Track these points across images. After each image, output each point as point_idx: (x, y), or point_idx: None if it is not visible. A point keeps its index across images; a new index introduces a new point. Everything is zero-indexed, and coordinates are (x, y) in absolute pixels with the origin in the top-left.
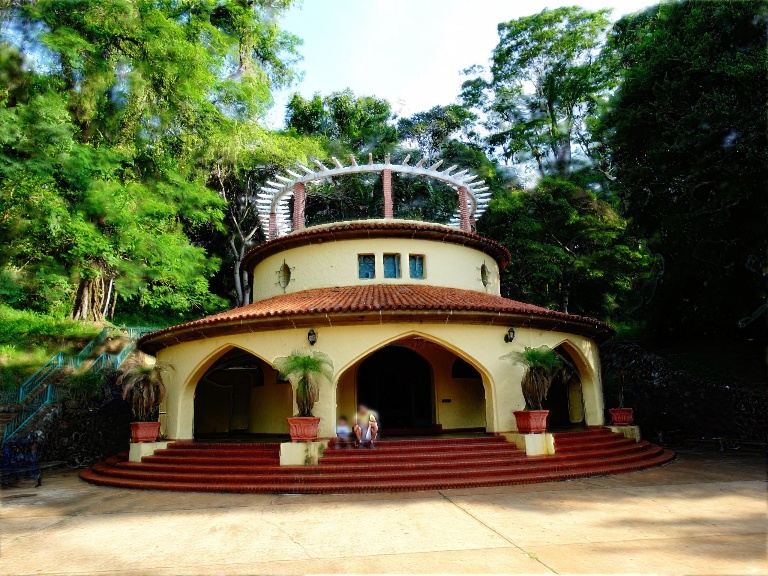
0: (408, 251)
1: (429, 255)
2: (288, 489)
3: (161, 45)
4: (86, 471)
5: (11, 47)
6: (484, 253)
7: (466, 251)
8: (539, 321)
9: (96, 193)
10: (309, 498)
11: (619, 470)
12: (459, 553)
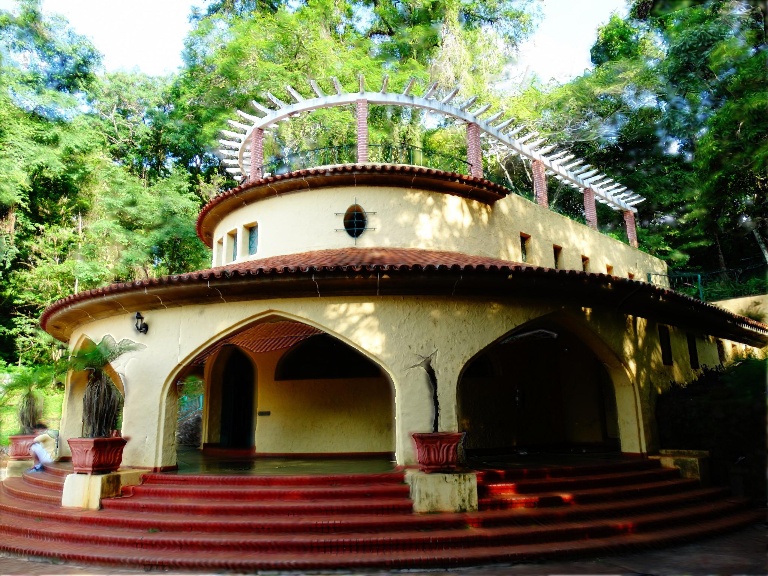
0: (242, 223)
1: (261, 220)
2: None
3: (281, 84)
4: None
5: (201, 143)
6: (361, 187)
7: (315, 196)
8: (175, 293)
9: None
10: None
11: (91, 559)
12: None
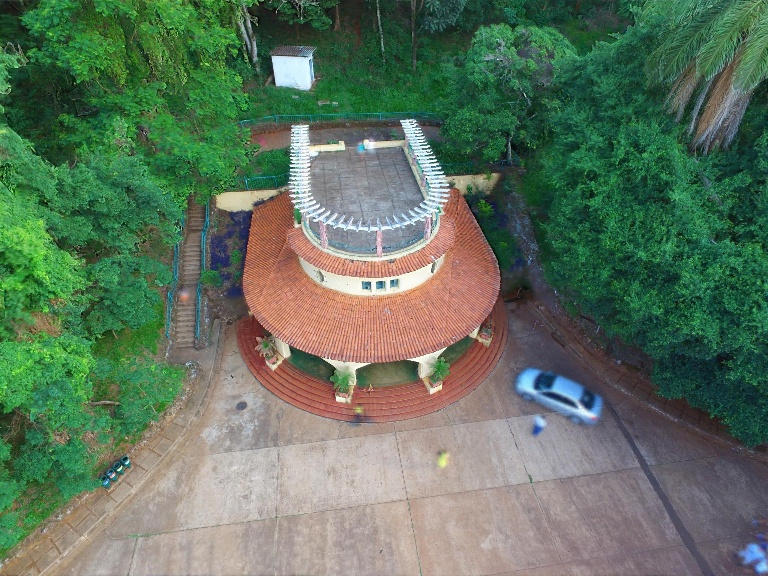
0: None
1: (401, 278)
2: (342, 420)
3: None
4: (244, 354)
5: (46, 65)
6: None
7: None
8: None
9: (158, 142)
10: (350, 429)
11: (464, 396)
12: (393, 504)
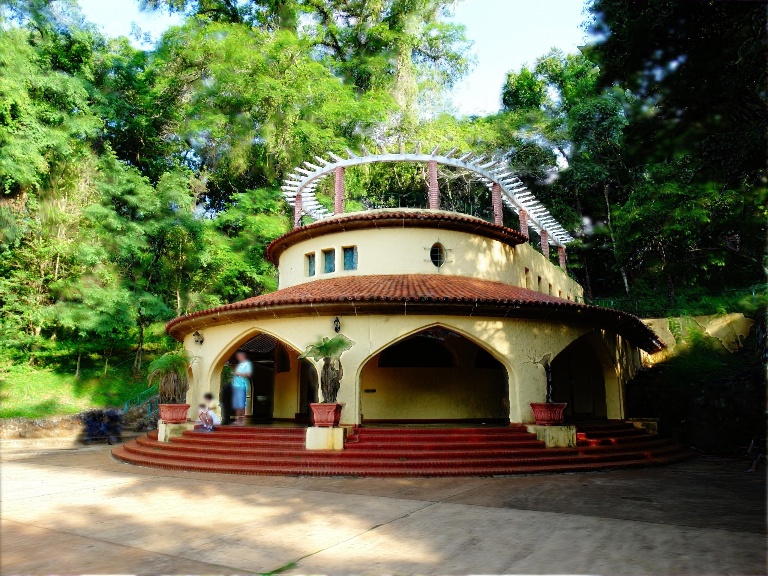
0: (341, 244)
1: (360, 245)
2: None
3: (274, 97)
4: None
5: (183, 136)
6: (441, 230)
7: (408, 233)
8: (372, 307)
9: None
10: None
11: (384, 474)
12: None
